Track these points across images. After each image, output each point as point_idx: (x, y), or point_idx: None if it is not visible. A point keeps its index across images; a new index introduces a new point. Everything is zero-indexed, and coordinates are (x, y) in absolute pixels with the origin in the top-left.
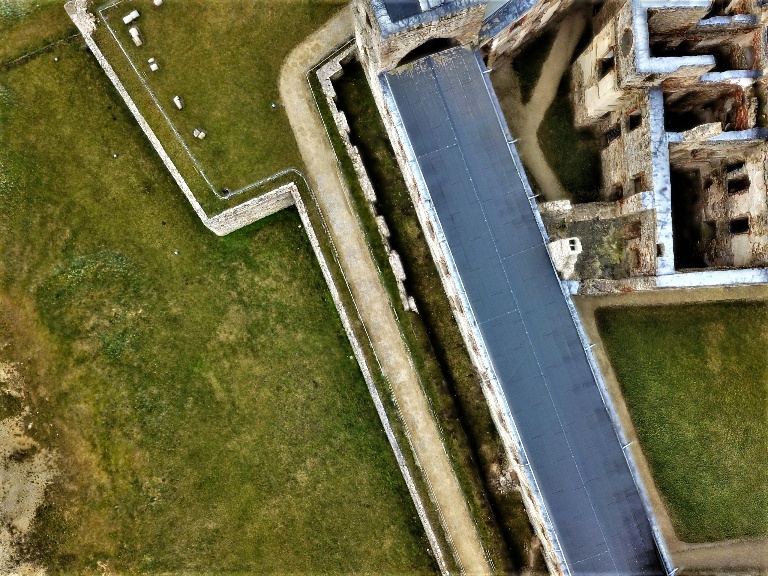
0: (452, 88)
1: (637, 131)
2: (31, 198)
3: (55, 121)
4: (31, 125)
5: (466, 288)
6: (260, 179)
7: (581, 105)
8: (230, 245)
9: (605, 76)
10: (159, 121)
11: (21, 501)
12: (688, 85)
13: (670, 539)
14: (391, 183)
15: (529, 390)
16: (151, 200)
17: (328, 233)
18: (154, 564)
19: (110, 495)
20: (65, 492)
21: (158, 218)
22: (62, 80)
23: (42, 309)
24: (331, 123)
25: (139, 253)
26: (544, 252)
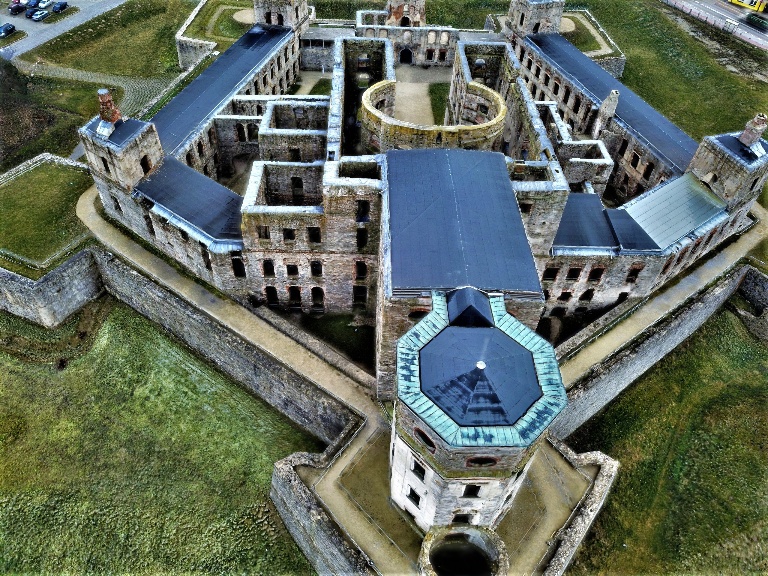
0: (689, 159)
1: None
2: None
3: None
4: None
5: None
6: None
7: None
8: None
9: None
10: None
11: None
12: None
13: None
14: None
15: (607, 80)
16: None
17: None
18: (730, 88)
19: (763, 105)
20: None
21: None
22: None
23: None
24: None
25: None
26: None
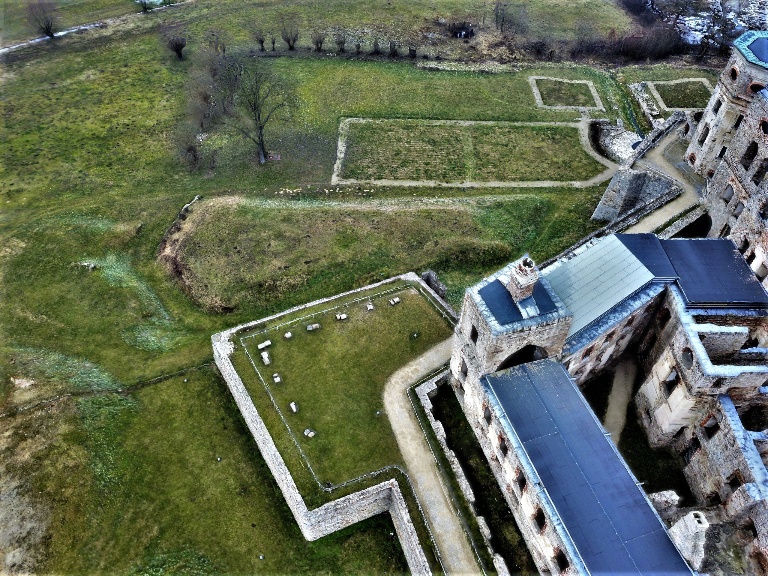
0: (546, 388)
1: (717, 436)
2: (129, 493)
3: (171, 428)
4: (149, 430)
5: (592, 574)
6: (362, 475)
7: (653, 426)
8: (318, 551)
9: (673, 392)
10: (274, 421)
11: None
12: (750, 398)
13: None
14: (486, 488)
15: None
16: (245, 502)
17: (429, 530)
18: None
19: None
20: None
21: (249, 520)
22: (186, 396)
23: None
24: (429, 429)
25: (222, 555)
26: (666, 538)
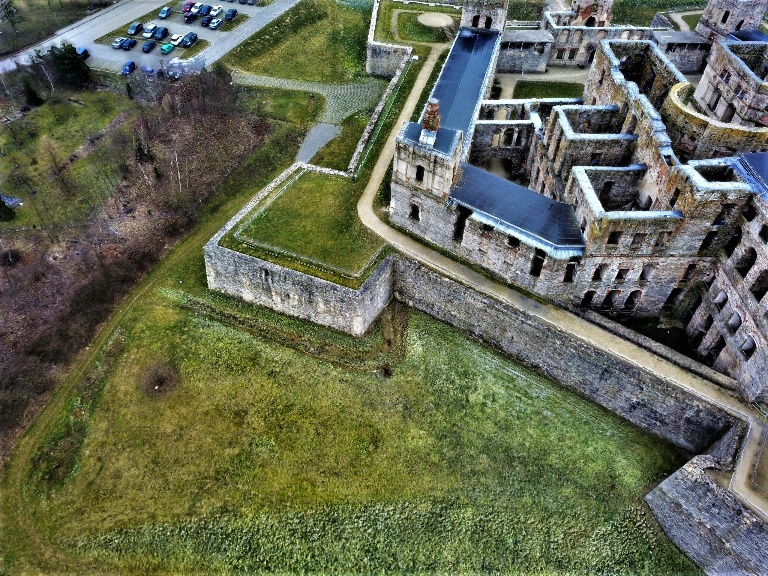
0: None
1: None
2: None
3: None
4: None
5: None
6: None
7: None
8: None
9: None
10: None
11: None
12: None
13: (691, 82)
14: None
15: None
16: None
17: None
18: None
19: None
20: None
21: None
22: None
23: None
24: None
25: None
26: None
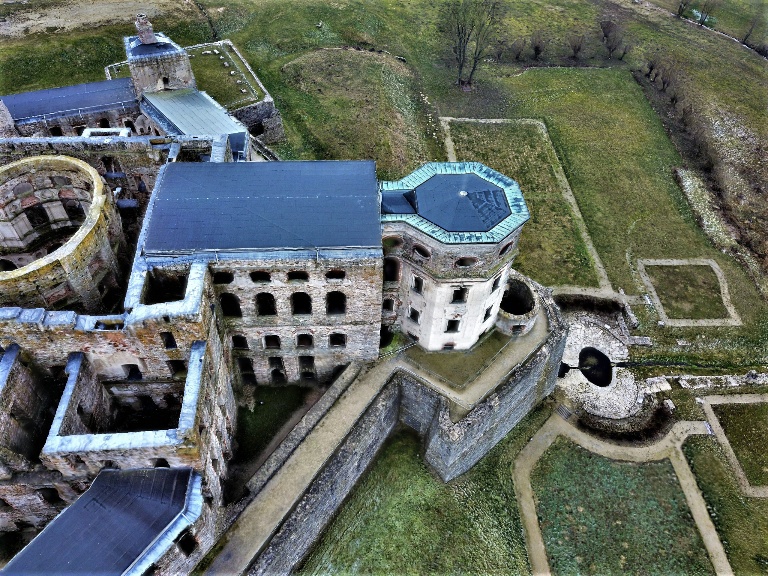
0: None
1: None
2: None
3: None
4: None
5: None
6: None
7: None
8: None
9: None
10: None
11: (5, 30)
12: None
13: None
14: None
15: None
16: None
17: None
18: None
19: None
20: (1, 39)
21: None
22: None
23: (93, 38)
24: None
25: None
26: None
